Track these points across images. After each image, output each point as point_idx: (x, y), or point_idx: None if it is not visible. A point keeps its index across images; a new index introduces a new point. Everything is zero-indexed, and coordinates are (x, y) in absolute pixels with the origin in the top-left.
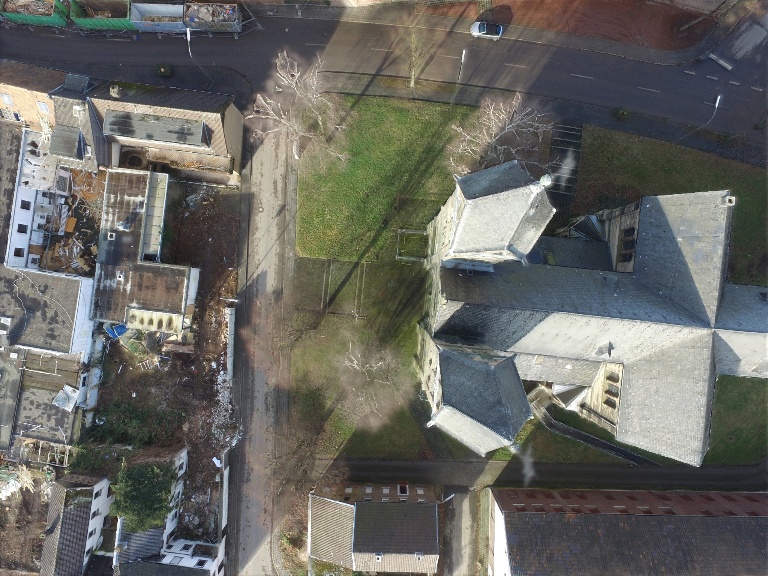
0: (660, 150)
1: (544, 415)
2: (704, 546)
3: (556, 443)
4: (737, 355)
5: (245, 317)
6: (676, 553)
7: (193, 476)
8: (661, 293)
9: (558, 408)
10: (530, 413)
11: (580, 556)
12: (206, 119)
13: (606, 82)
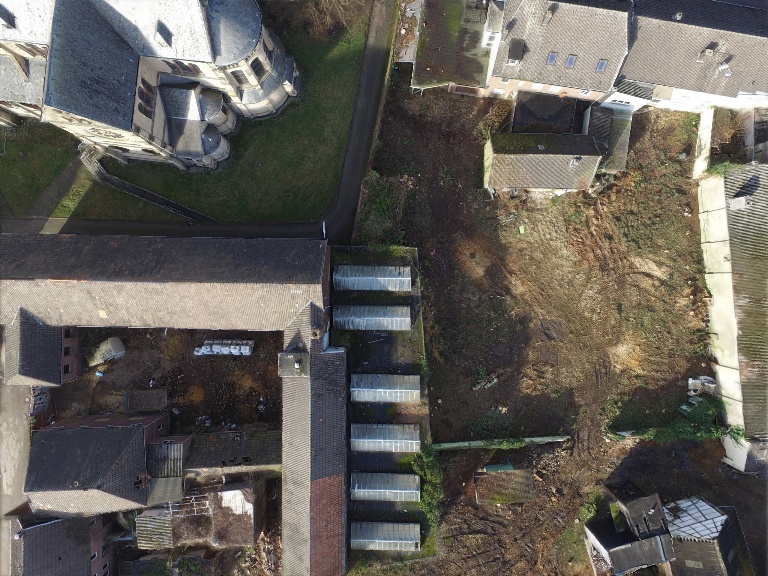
0: None
1: (98, 169)
2: (181, 258)
3: (115, 199)
4: (125, 17)
5: None
6: (149, 262)
7: None
8: None
9: (116, 164)
10: None
11: (51, 264)
12: None
13: None
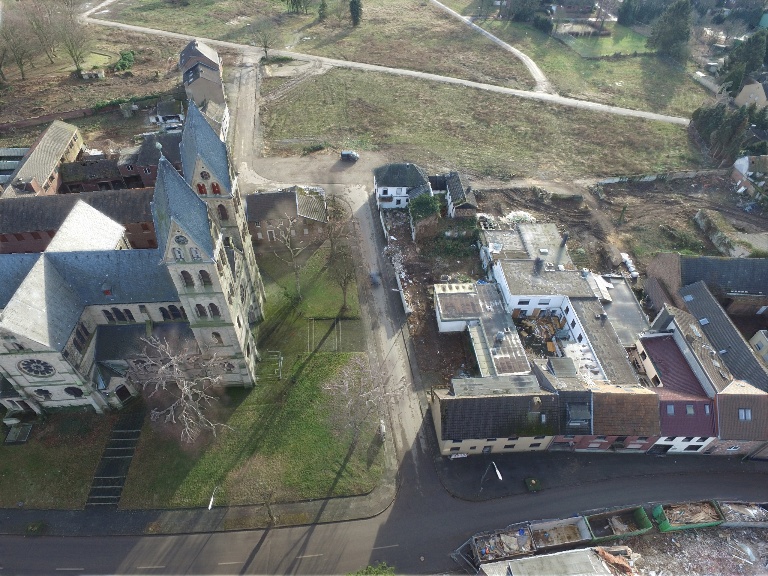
0: (3, 495)
1: None
2: None
3: None
4: None
5: (397, 310)
6: (99, 206)
7: (406, 231)
8: (70, 285)
9: None
10: (181, 145)
11: None
12: (453, 397)
13: (41, 568)
